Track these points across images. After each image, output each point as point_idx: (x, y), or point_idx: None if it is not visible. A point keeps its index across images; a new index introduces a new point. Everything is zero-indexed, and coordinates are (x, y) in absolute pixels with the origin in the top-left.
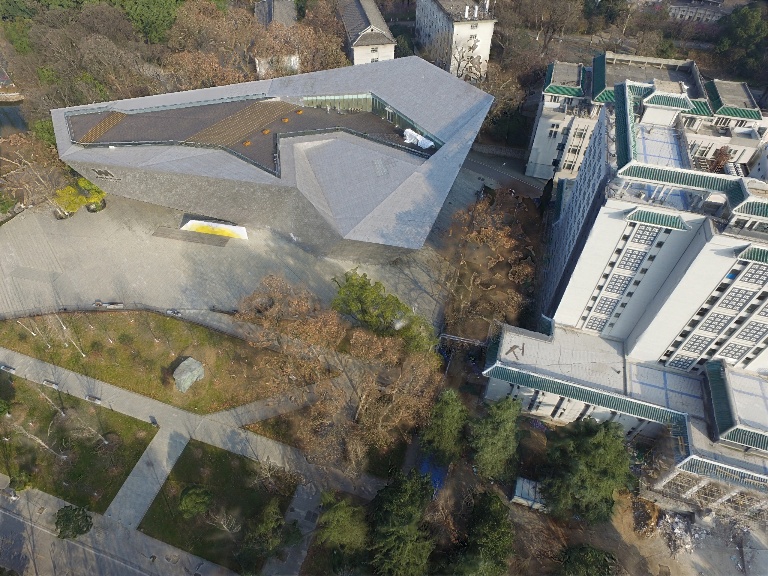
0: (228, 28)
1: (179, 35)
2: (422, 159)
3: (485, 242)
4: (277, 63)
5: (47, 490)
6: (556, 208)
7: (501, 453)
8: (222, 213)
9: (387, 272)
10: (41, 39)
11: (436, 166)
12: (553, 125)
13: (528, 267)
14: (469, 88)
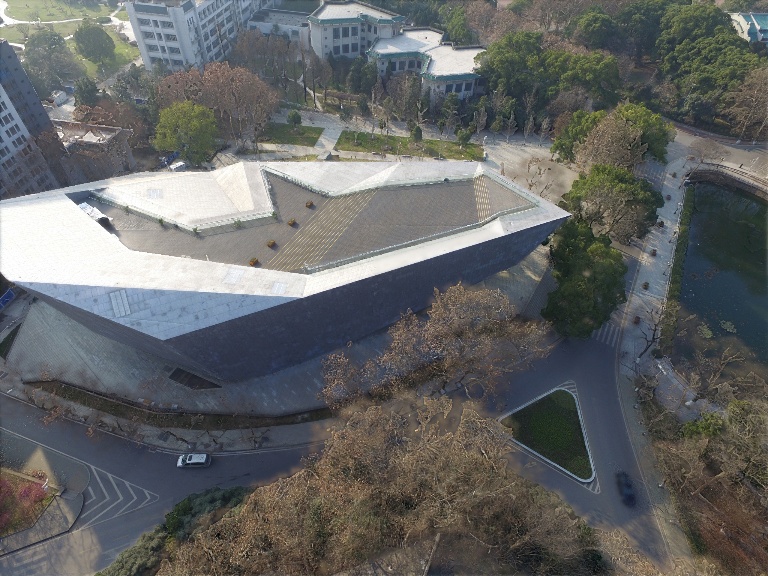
0: None
1: None
2: None
3: None
4: None
5: None
6: None
7: None
8: None
9: None
10: None
11: (91, 187)
12: None
13: None
14: None
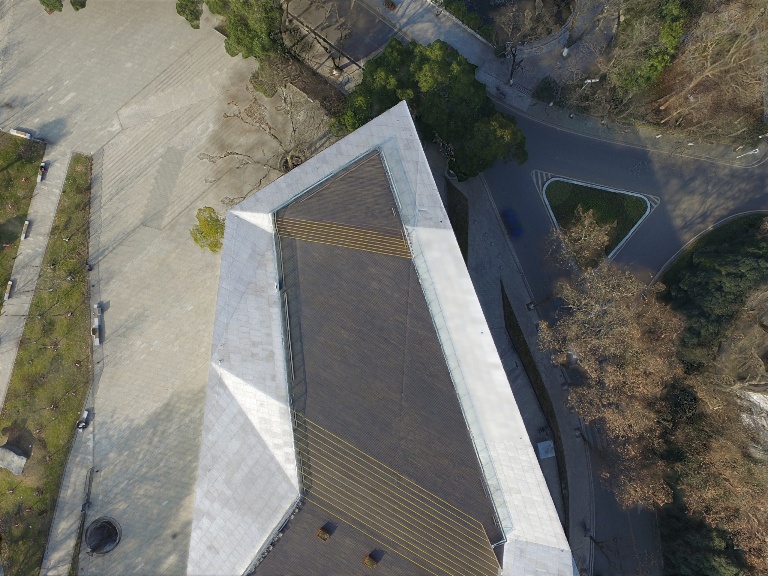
0: None
1: None
2: None
3: None
4: None
5: None
6: None
7: None
8: None
9: None
10: None
11: None
12: None
13: None
14: None
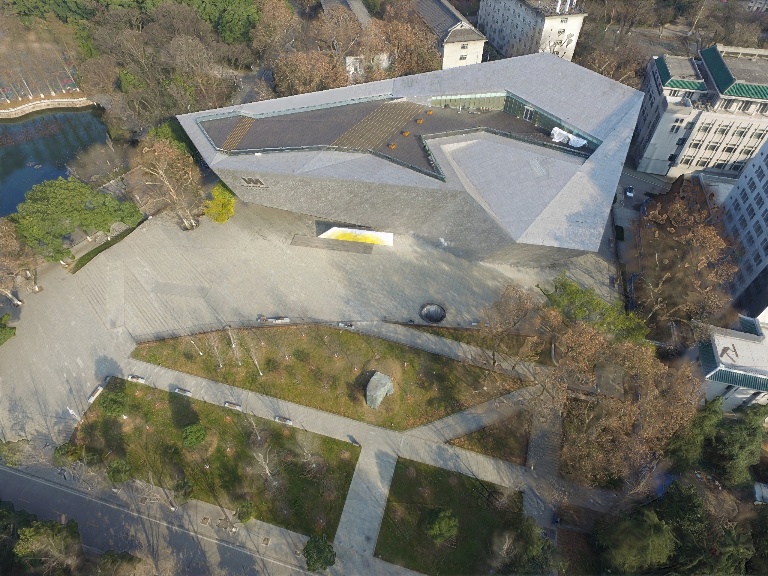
0: (329, 26)
1: (265, 34)
2: (580, 158)
3: (701, 243)
4: (377, 62)
5: (265, 519)
6: (701, 204)
7: (751, 459)
8: (367, 219)
9: (548, 275)
10: (106, 41)
11: (598, 165)
12: (677, 120)
13: (736, 267)
14: (614, 84)
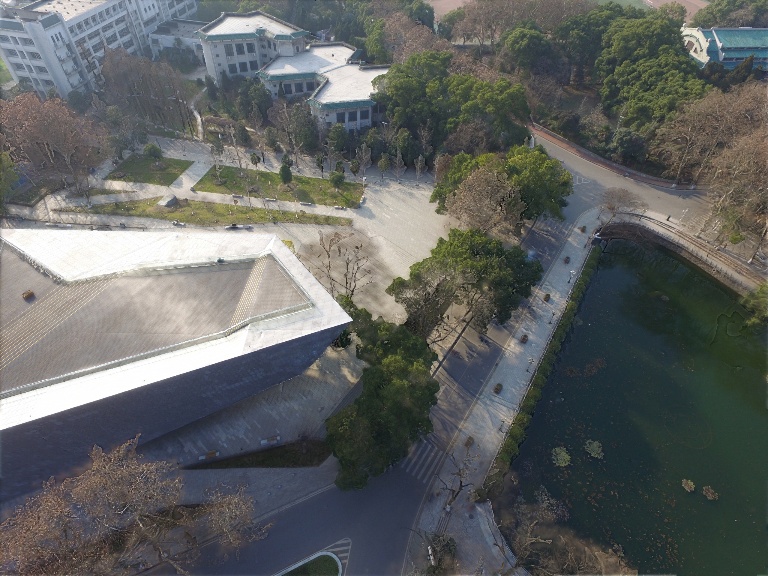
0: None
1: None
2: None
3: None
4: None
5: None
6: None
7: None
8: None
9: None
10: None
11: None
12: None
13: None
14: None
